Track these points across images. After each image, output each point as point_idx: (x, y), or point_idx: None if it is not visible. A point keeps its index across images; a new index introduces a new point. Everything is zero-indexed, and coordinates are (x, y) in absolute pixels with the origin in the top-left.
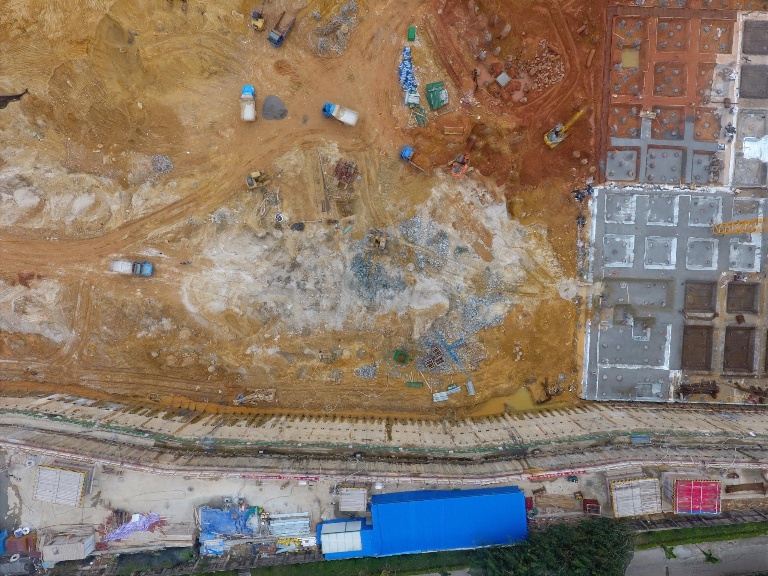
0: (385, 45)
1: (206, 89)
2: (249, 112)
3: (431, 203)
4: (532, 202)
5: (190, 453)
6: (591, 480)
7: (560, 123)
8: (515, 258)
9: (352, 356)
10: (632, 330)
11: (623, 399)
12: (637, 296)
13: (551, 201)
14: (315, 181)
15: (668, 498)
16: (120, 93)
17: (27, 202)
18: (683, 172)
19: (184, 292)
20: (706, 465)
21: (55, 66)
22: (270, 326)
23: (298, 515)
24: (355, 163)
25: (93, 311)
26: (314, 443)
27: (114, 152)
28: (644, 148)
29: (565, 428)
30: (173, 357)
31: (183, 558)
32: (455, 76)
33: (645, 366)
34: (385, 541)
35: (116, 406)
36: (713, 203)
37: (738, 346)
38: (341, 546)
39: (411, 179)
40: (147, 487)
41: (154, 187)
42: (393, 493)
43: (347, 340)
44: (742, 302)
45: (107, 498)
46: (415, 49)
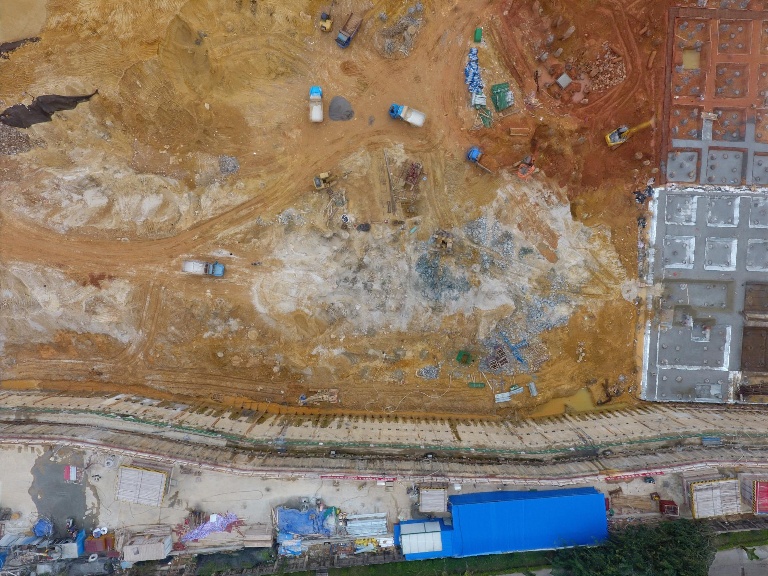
0: (451, 46)
1: (273, 90)
2: (317, 113)
3: (496, 204)
4: (593, 203)
5: (263, 453)
6: (667, 481)
7: (622, 124)
8: (580, 259)
9: (415, 357)
10: (691, 331)
11: (683, 400)
12: (697, 297)
13: (612, 202)
14: (381, 182)
15: (746, 499)
16: (187, 94)
17: (96, 202)
18: (744, 173)
19: (254, 293)
20: None
21: (126, 67)
22: (336, 327)
23: (375, 515)
24: (421, 164)
25: (161, 311)
26: (386, 444)
27: (181, 153)
28: (705, 149)
29: (633, 429)
30: (238, 357)
31: (263, 558)
32: (518, 77)
33: (704, 367)
34: (466, 542)
35: (182, 406)
36: None
37: None
38: (421, 547)
39: (477, 180)
40: (225, 487)
41: (222, 188)
42: (470, 494)
43: (410, 341)
44: None
45: (185, 498)
46: (481, 50)
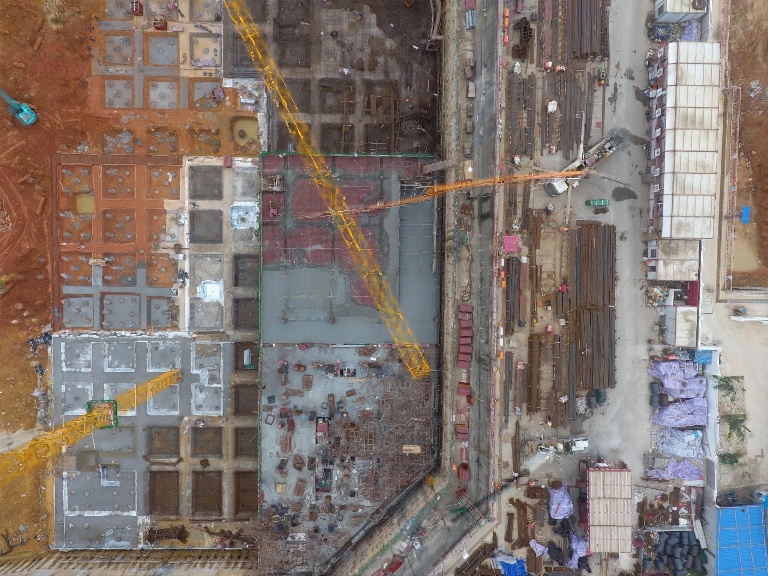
0: None
1: None
2: None
3: None
4: None
5: None
6: None
7: (3, 274)
8: None
9: None
10: (101, 476)
11: (88, 548)
12: (103, 442)
13: (1, 352)
14: None
15: None
16: None
17: None
18: None
19: None
20: None
21: None
22: None
23: None
24: None
25: None
26: None
27: None
28: (96, 295)
29: None
30: None
31: None
32: None
33: (114, 512)
34: None
35: None
36: (174, 347)
37: (210, 489)
38: None
39: None
40: None
41: None
42: None
43: None
44: (210, 445)
45: None
46: None
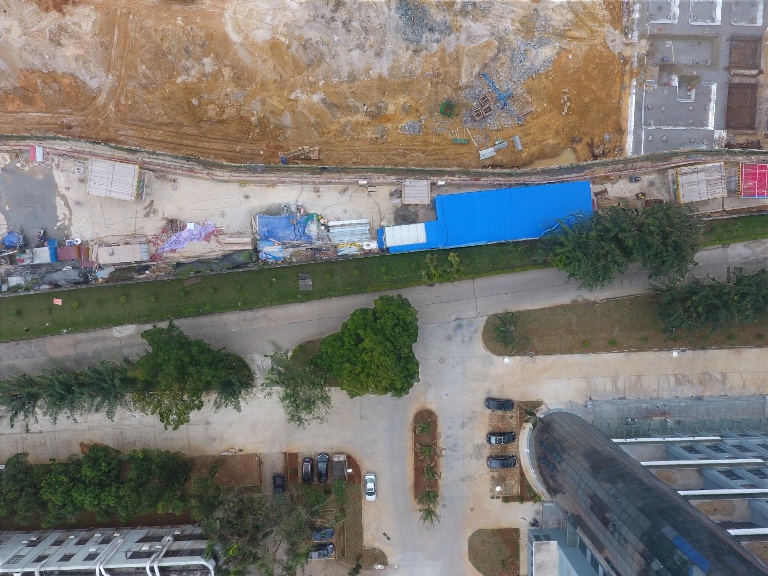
0: None
1: None
2: None
3: None
4: None
5: None
6: None
7: None
8: None
9: (397, 111)
10: (677, 91)
11: None
12: (682, 55)
13: None
14: None
15: (731, 190)
16: None
17: None
18: None
19: (227, 19)
20: (767, 161)
21: None
22: (314, 69)
23: (358, 222)
24: None
25: (131, 48)
26: None
27: None
28: None
29: None
30: (214, 106)
31: (243, 259)
32: None
33: (690, 127)
34: (450, 232)
35: None
36: None
37: None
38: (405, 239)
39: None
40: (202, 195)
41: None
42: None
43: (392, 93)
44: None
45: (160, 207)
46: None
